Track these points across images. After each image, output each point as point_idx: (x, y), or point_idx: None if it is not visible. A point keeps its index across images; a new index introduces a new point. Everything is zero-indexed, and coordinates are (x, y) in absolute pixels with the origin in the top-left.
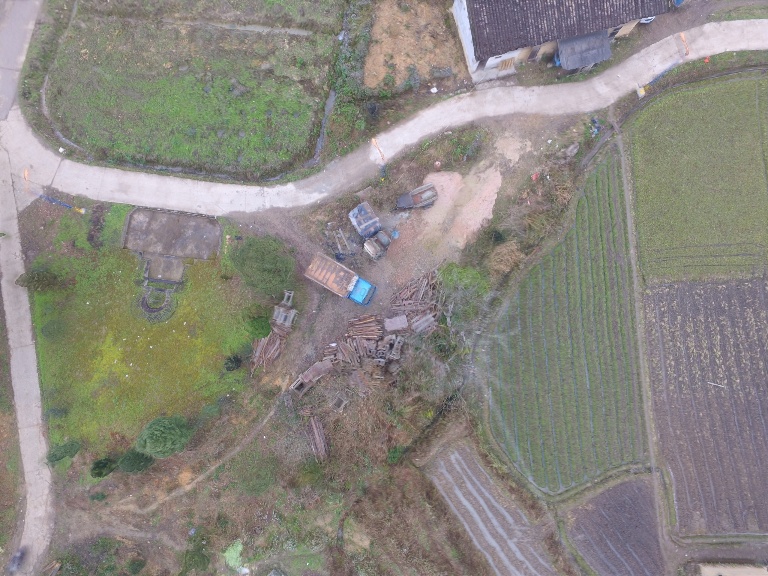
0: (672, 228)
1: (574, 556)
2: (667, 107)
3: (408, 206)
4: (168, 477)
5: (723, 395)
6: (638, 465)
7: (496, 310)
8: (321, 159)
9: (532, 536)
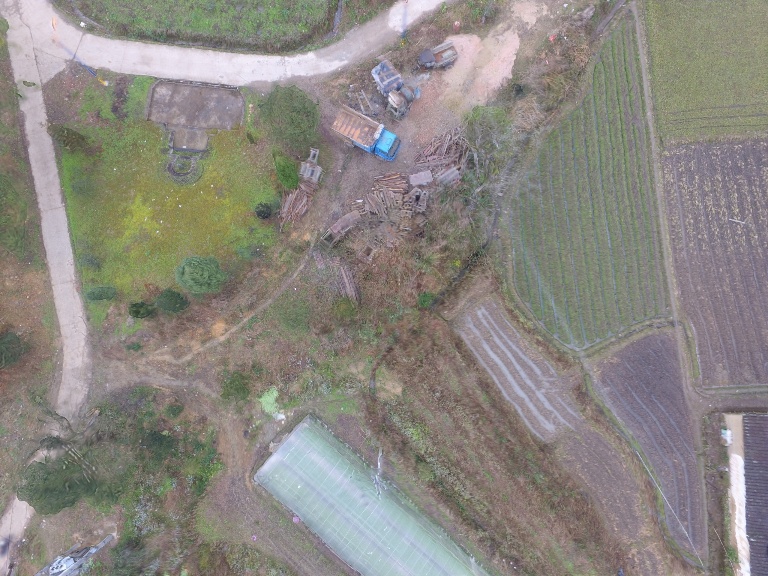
0: (687, 91)
1: (601, 407)
2: None
3: (429, 64)
4: (202, 329)
5: (742, 251)
6: (661, 319)
7: (517, 172)
8: (340, 29)
9: (560, 386)
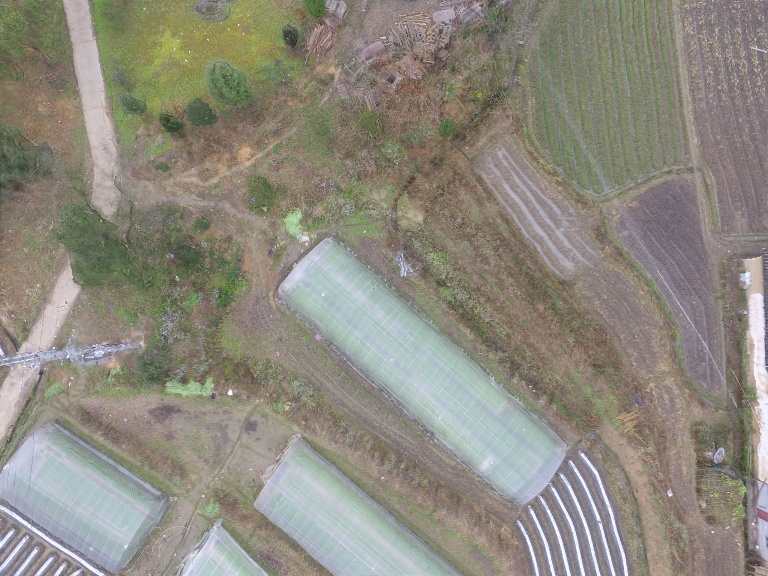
0: None
1: (619, 250)
2: None
3: None
4: (228, 154)
5: (762, 102)
6: (680, 166)
7: (538, 20)
8: None
9: (579, 225)
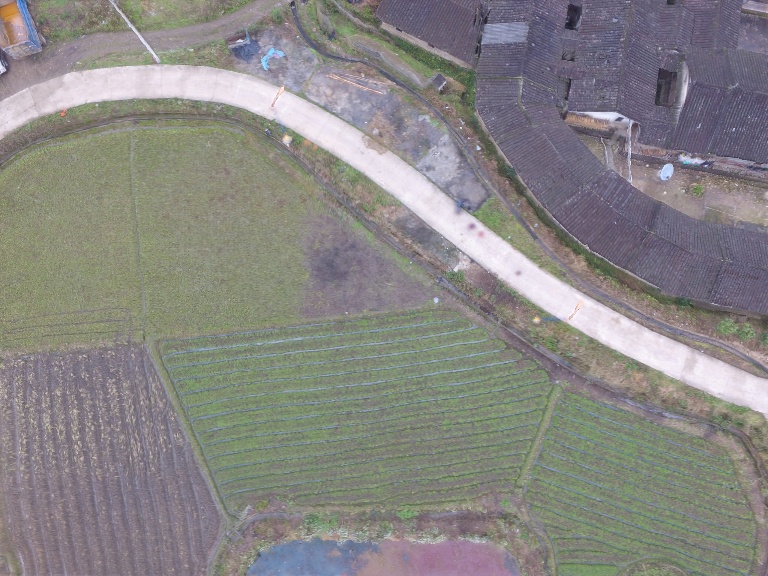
0: (30, 296)
1: None
2: (31, 165)
3: None
4: None
5: (78, 473)
6: None
7: None
8: None
9: None
